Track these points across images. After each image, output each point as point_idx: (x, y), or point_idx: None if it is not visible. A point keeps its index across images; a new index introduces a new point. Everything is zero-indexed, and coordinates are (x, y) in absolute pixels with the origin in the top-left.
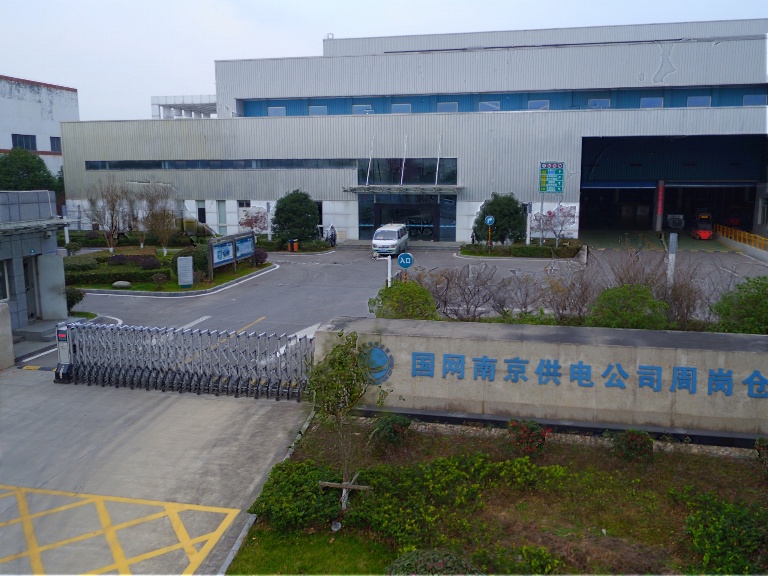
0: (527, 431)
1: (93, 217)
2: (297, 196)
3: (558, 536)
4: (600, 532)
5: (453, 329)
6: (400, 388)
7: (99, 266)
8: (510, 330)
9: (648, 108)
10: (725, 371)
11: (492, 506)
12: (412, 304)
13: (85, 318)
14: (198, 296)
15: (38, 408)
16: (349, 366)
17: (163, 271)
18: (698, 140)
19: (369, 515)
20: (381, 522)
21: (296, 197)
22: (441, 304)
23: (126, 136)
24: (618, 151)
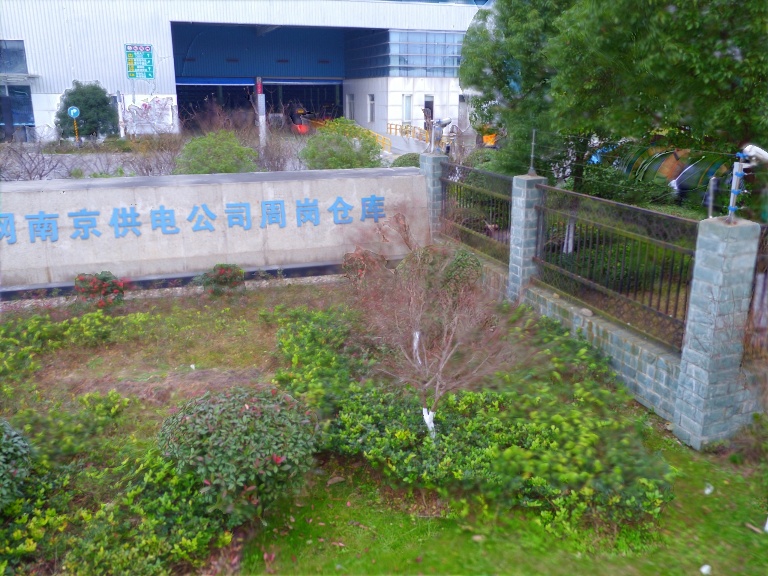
0: (97, 282)
1: None
2: None
3: (137, 381)
4: (188, 368)
5: None
6: None
7: None
8: (75, 182)
9: None
10: (311, 201)
11: (55, 370)
12: None
13: None
14: None
15: None
16: None
17: None
18: (288, 37)
19: None
20: None
21: None
22: None
23: None
24: (213, 45)
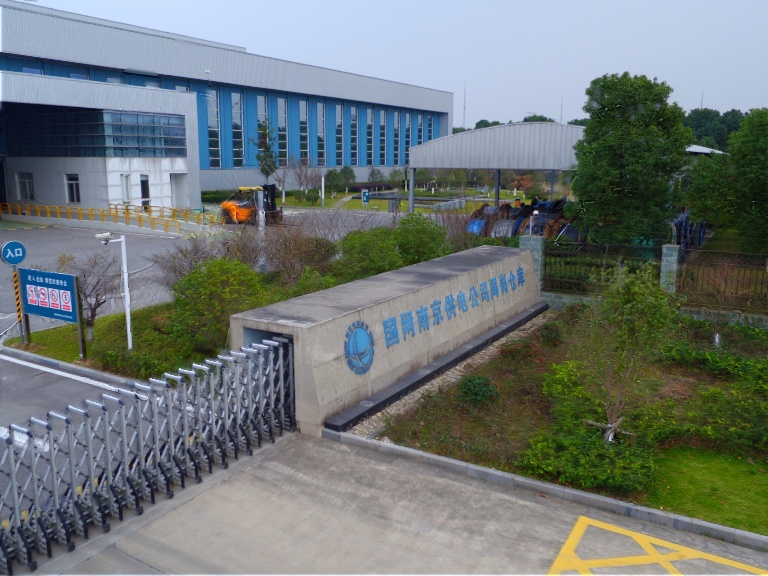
0: None
1: None
2: None
3: None
4: None
5: None
6: (382, 366)
7: None
8: (391, 281)
9: None
10: (503, 275)
11: None
12: None
13: None
14: None
15: None
16: None
17: None
18: None
19: None
20: (661, 433)
21: None
22: None
23: None
24: None
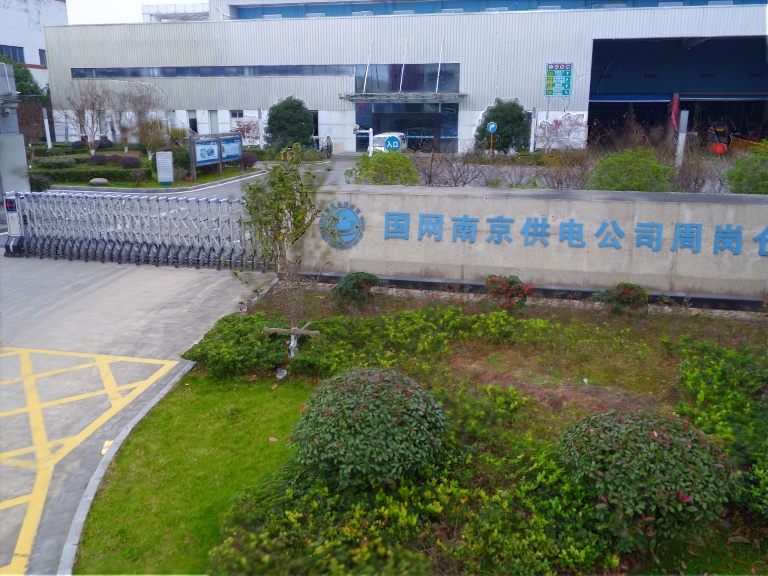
0: (506, 284)
1: (72, 117)
2: (290, 103)
3: (532, 384)
4: (581, 381)
5: (432, 190)
6: (372, 252)
7: (77, 165)
8: (496, 191)
9: (665, 7)
10: (734, 227)
11: (461, 358)
12: (391, 172)
13: None
14: (178, 193)
15: None
16: (291, 183)
17: (144, 170)
18: (717, 49)
19: (317, 359)
20: (330, 366)
21: (289, 104)
22: (426, 179)
23: (112, 41)
24: (632, 61)
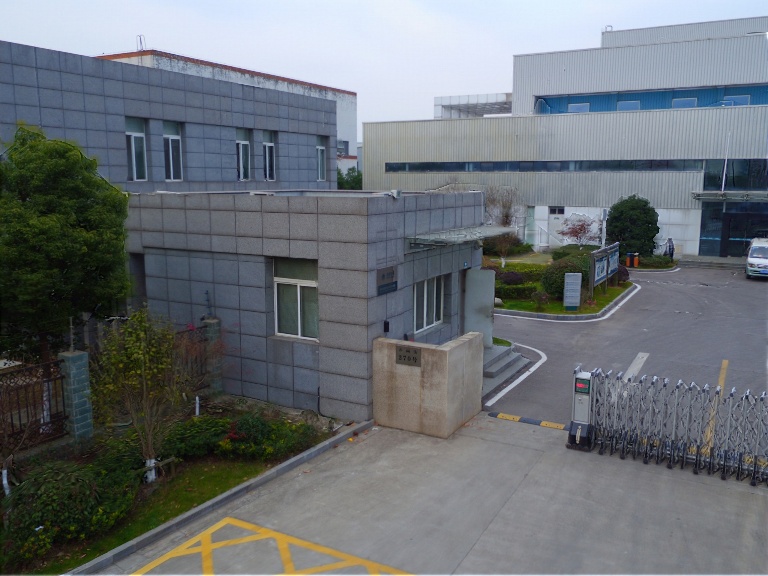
0: None
1: None
2: (636, 202)
3: None
4: None
5: None
6: None
7: None
8: None
9: None
10: None
11: None
12: None
13: (509, 347)
14: (591, 321)
15: (591, 494)
16: None
17: (530, 287)
18: None
19: None
20: None
21: (635, 204)
22: None
23: (430, 137)
24: None
